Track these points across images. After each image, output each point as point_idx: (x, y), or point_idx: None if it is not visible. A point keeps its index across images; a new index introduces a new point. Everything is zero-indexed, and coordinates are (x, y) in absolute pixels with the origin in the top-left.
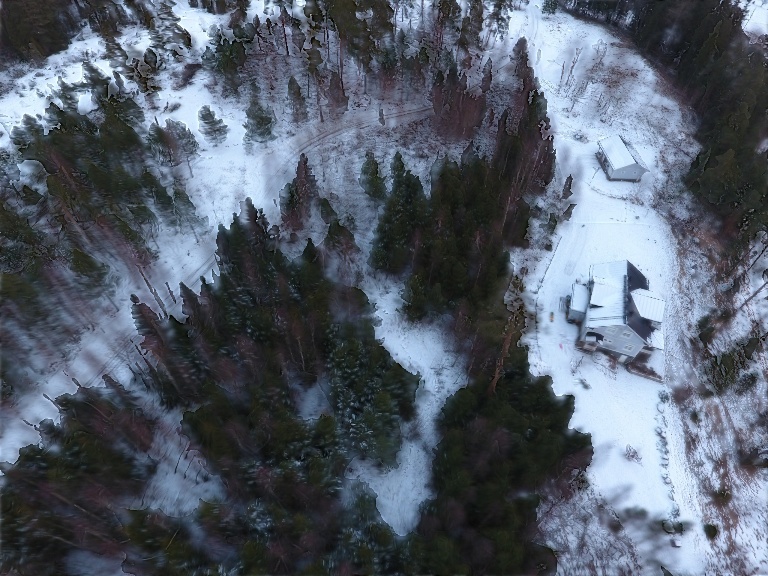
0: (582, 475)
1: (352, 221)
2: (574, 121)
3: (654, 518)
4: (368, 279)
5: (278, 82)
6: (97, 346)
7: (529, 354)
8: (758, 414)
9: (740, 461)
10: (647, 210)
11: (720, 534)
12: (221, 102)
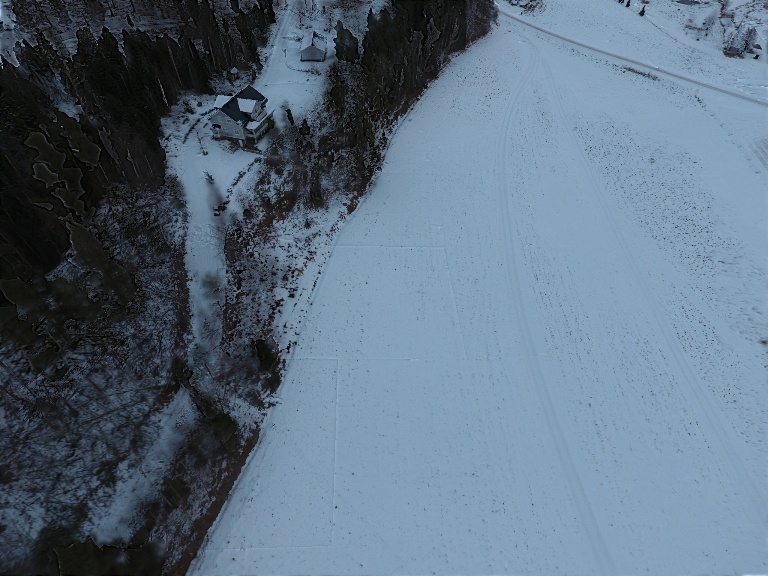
0: (173, 186)
1: (55, 60)
2: (303, 31)
3: (211, 205)
4: (70, 98)
5: (66, 5)
6: None
7: (174, 139)
8: (347, 183)
9: (310, 199)
10: (321, 77)
11: (258, 218)
12: (14, 15)
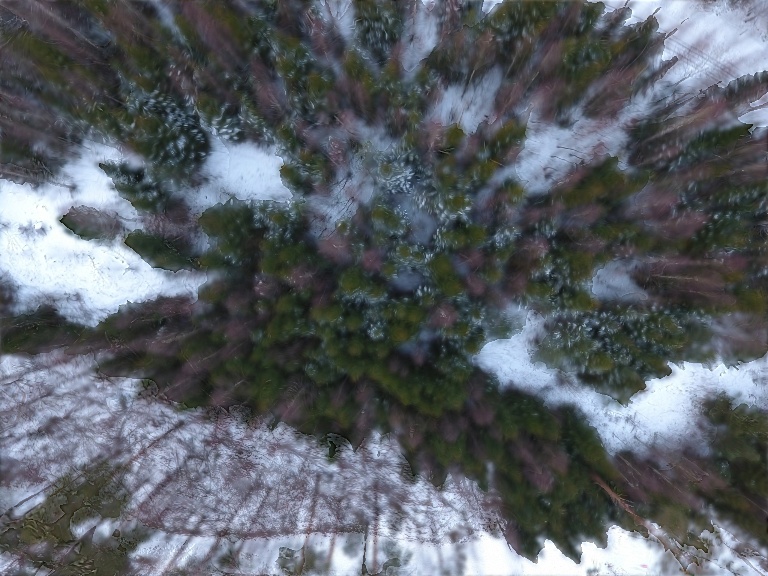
0: None
1: None
2: None
3: (456, 574)
4: None
5: None
6: (721, 31)
7: None
8: None
9: None
10: None
11: None
12: None
